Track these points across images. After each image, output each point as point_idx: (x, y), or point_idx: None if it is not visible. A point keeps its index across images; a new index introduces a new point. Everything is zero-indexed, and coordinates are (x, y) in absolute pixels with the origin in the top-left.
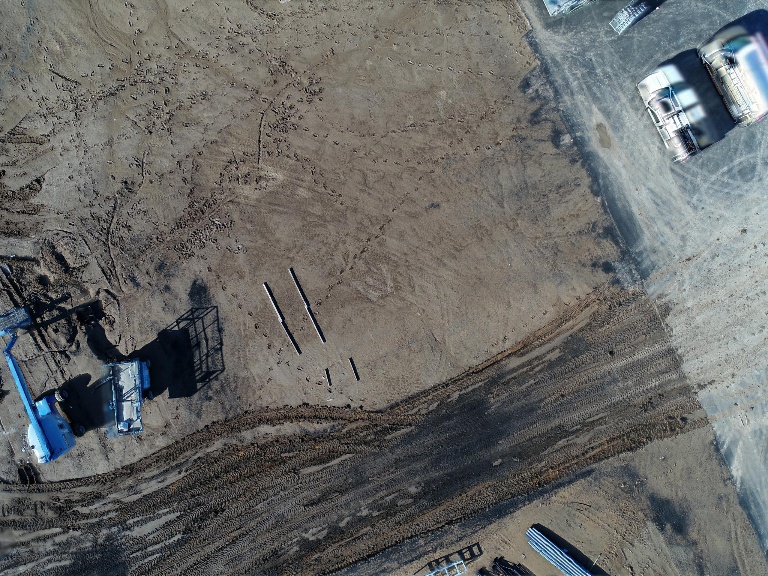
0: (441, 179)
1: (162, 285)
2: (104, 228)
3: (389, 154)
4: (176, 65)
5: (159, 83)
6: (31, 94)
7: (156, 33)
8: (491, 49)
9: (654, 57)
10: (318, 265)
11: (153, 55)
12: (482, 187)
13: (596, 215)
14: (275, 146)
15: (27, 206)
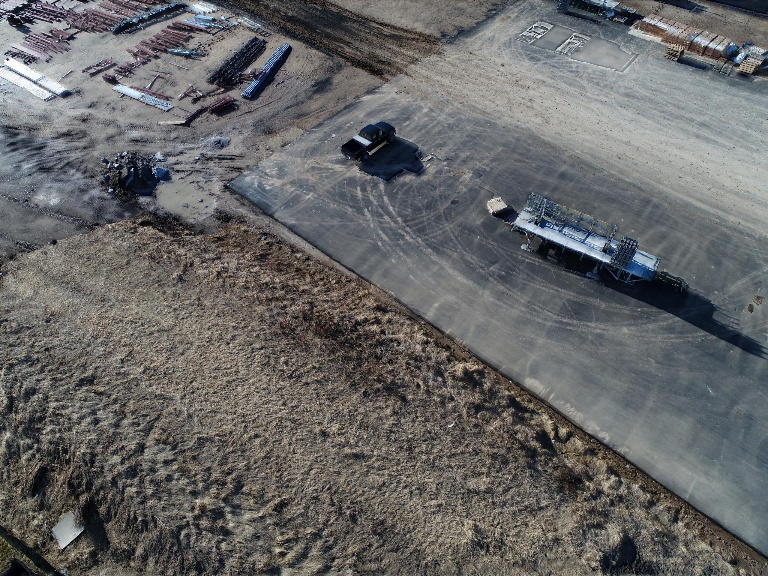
0: None
1: None
2: None
3: None
4: None
5: None
6: None
7: None
8: None
9: None
10: None
11: None
12: None
13: None
14: None
15: None
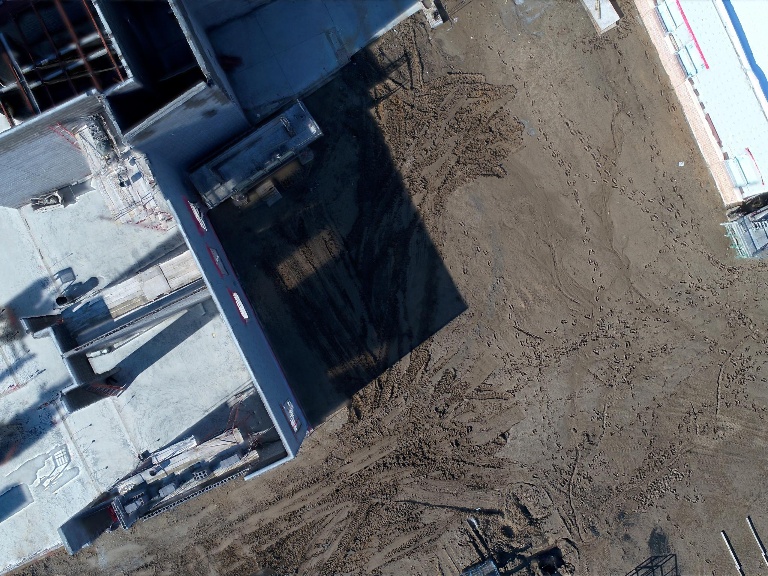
0: None
1: (621, 534)
2: (566, 480)
3: None
4: (637, 320)
5: (620, 338)
6: (496, 351)
7: (618, 289)
8: None
9: None
10: None
11: (615, 310)
12: None
13: None
14: (733, 397)
15: (492, 460)
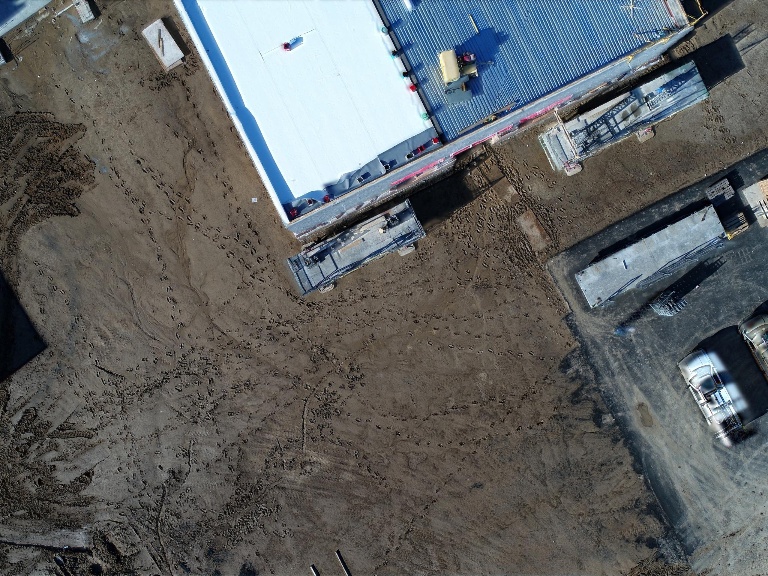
0: (484, 459)
1: (212, 570)
2: (153, 517)
3: (431, 436)
4: (219, 356)
5: (203, 374)
6: (78, 390)
7: (198, 326)
8: (531, 330)
9: (695, 335)
10: (364, 546)
11: (196, 347)
12: (525, 466)
13: (639, 492)
14: (319, 432)
15: (78, 499)
